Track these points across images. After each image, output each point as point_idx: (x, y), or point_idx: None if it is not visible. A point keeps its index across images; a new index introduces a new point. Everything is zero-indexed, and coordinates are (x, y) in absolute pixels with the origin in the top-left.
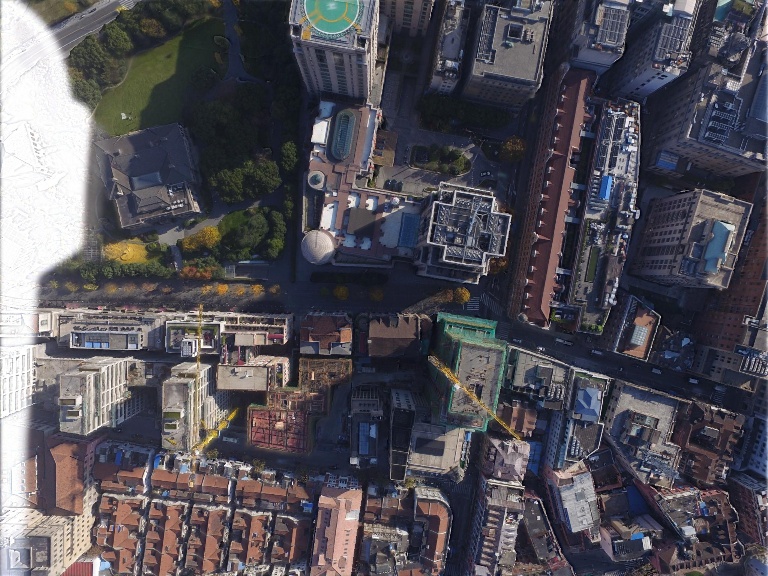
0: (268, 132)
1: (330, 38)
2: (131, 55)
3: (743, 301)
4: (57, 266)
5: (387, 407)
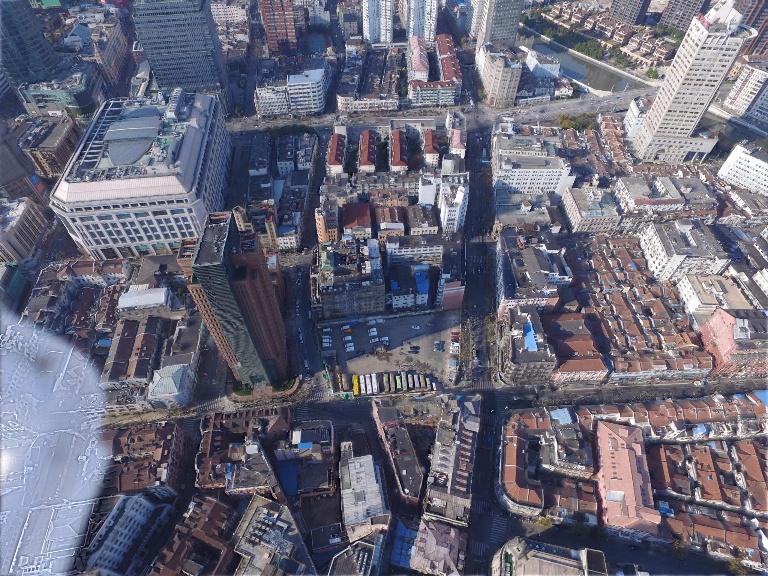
0: None
1: None
2: None
3: None
4: None
5: None
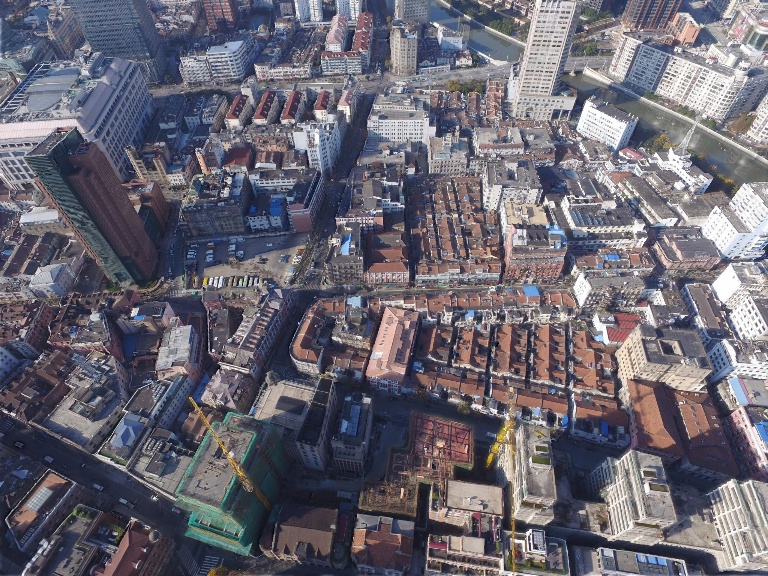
0: None
1: None
2: None
3: None
4: None
5: (329, 451)
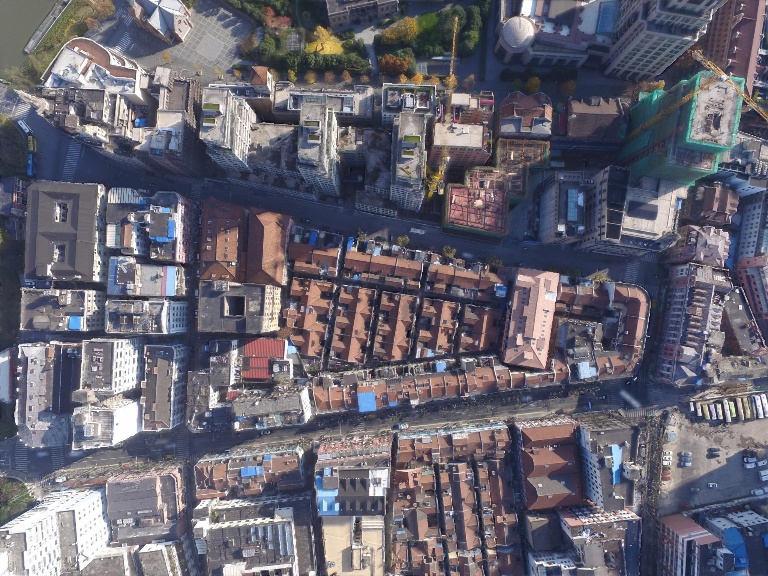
0: None
1: None
2: None
3: None
4: (263, 53)
5: None
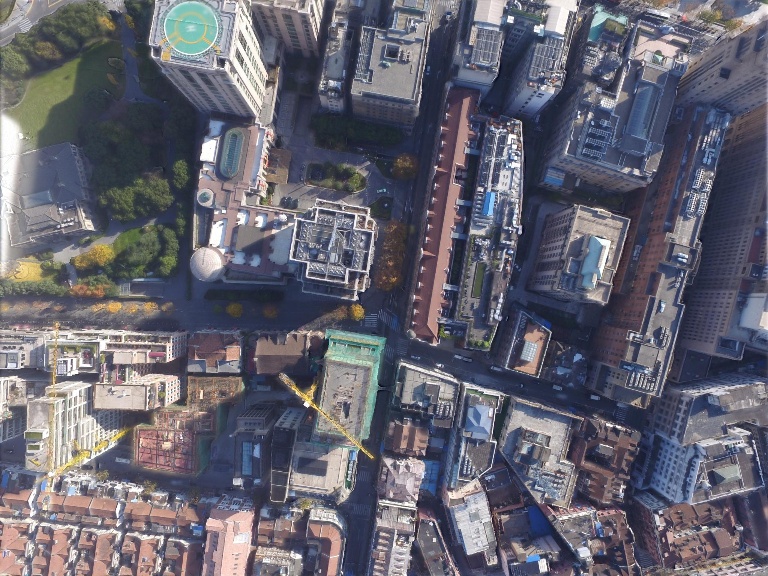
0: (164, 151)
1: (190, 59)
2: (29, 77)
3: (631, 316)
4: None
5: None
